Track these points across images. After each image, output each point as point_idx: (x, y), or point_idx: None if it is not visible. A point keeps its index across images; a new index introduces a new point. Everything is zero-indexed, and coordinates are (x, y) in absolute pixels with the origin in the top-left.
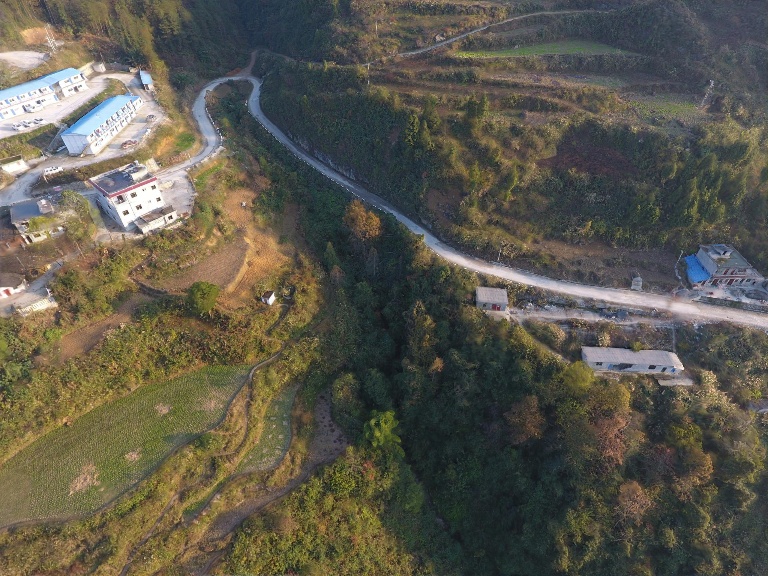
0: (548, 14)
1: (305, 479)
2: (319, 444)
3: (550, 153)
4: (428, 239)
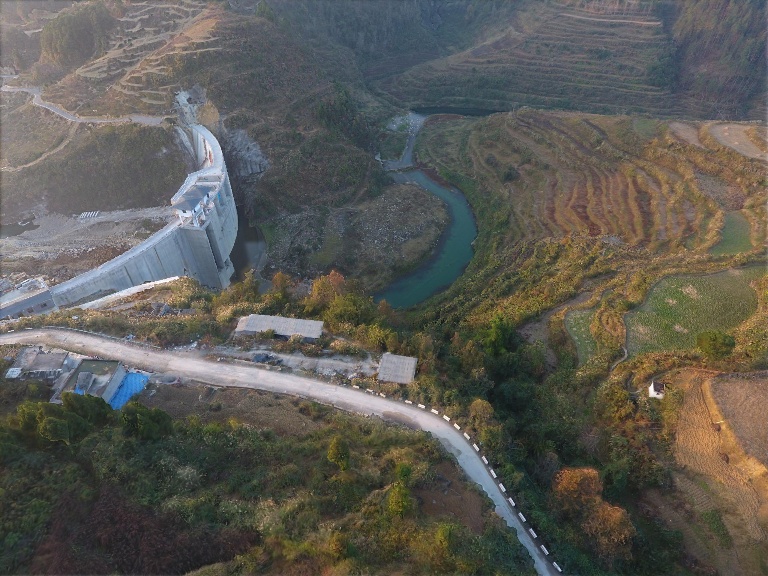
0: None
1: (545, 314)
2: (543, 334)
3: (198, 575)
4: (473, 463)
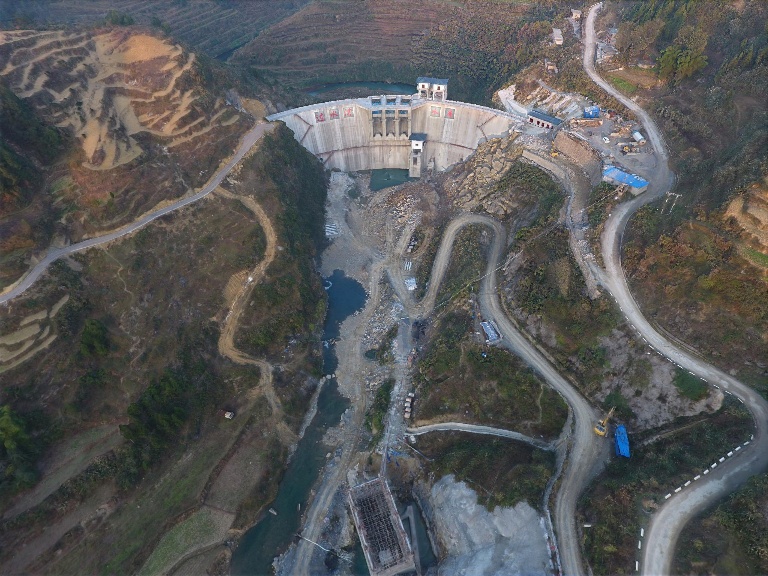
0: None
1: None
2: None
3: None
4: None
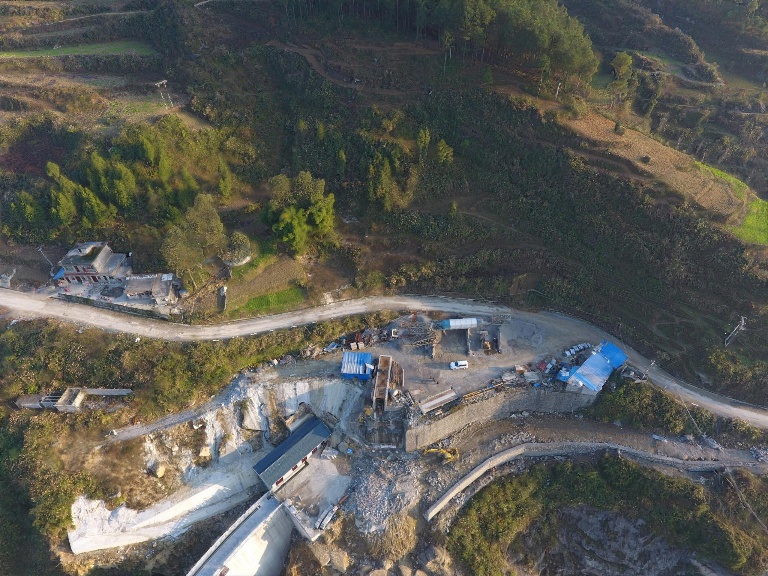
0: (106, 15)
1: None
2: None
3: None
4: None
